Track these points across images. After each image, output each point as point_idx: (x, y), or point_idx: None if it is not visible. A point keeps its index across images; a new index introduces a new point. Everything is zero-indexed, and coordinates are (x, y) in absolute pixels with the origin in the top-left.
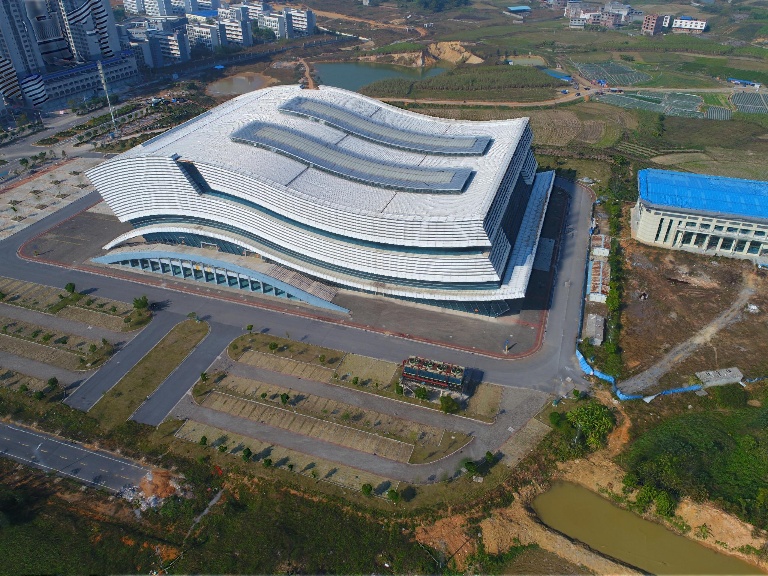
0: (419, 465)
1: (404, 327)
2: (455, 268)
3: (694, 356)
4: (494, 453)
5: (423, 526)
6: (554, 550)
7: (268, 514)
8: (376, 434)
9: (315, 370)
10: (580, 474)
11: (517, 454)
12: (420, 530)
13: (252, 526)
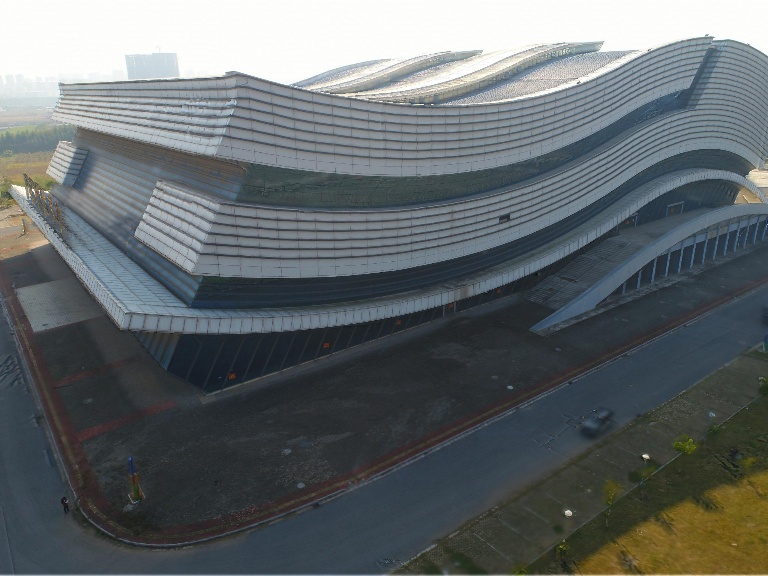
0: None
1: None
2: None
3: None
4: None
5: None
6: None
7: None
8: None
9: None
10: None
11: None
12: None
13: None
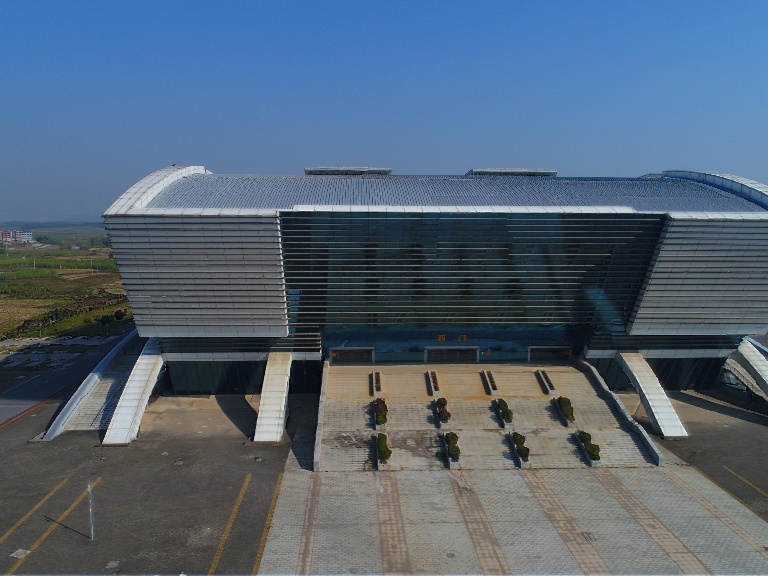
0: None
1: None
2: None
3: None
4: None
5: None
6: None
7: None
8: None
9: None
10: None
11: None
12: None
13: None
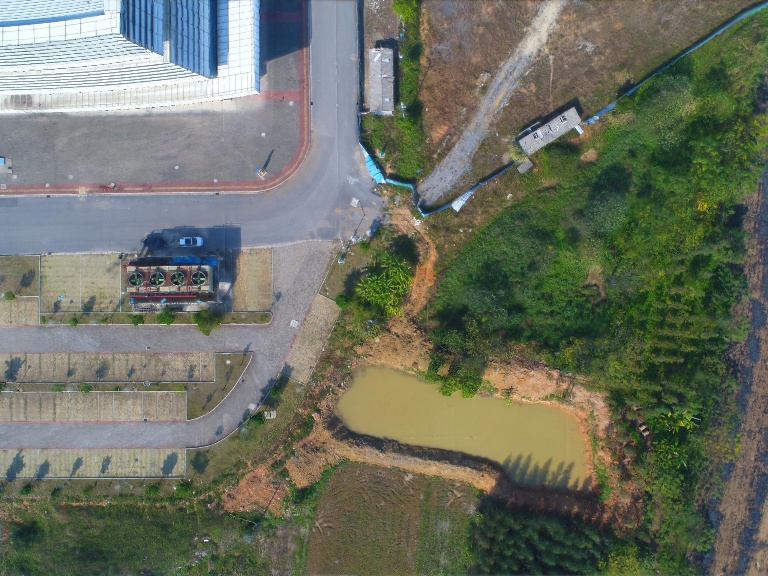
0: (200, 419)
1: (101, 169)
2: (125, 77)
3: (521, 88)
4: (281, 369)
5: (228, 492)
6: (365, 461)
7: (62, 542)
8: (135, 390)
9: (11, 307)
10: (382, 355)
11: (307, 362)
12: (226, 499)
13: (52, 562)
